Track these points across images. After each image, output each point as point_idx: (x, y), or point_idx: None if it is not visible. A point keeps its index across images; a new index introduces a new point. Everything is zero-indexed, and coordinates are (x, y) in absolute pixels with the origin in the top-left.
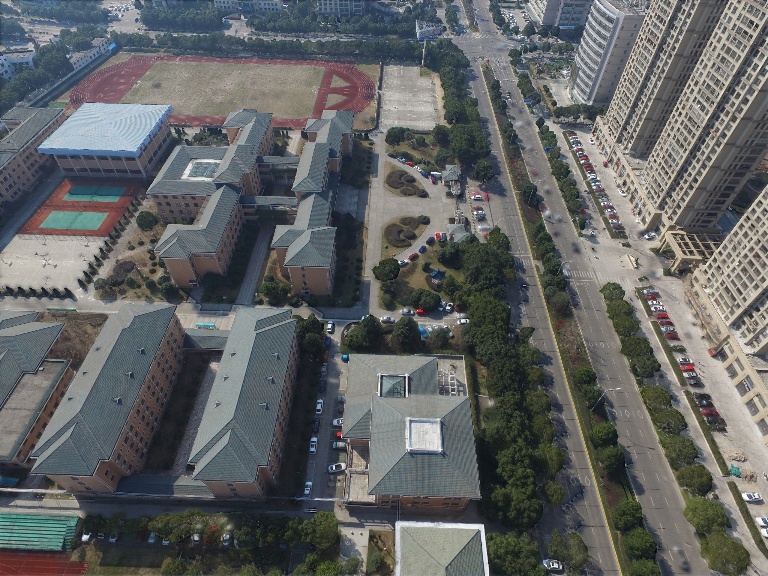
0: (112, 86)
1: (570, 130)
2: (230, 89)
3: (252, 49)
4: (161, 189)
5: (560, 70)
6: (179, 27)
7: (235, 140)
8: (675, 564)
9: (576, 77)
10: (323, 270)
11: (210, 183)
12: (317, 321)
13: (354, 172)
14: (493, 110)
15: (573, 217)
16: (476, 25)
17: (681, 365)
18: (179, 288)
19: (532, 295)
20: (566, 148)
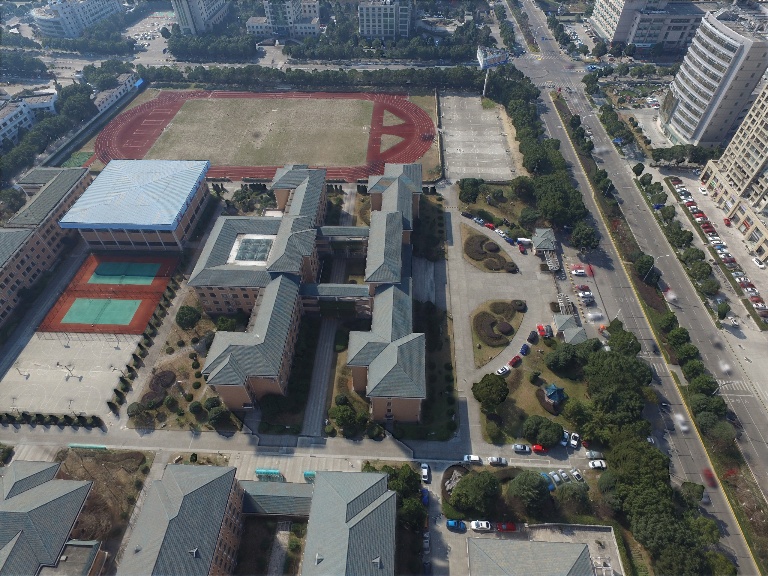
0: (140, 131)
1: (673, 176)
2: (271, 131)
3: (291, 81)
4: (205, 280)
5: (643, 97)
6: (210, 57)
7: (287, 207)
8: None
9: (673, 110)
10: (415, 399)
11: (263, 271)
12: (414, 476)
13: (425, 238)
14: (575, 151)
15: (704, 299)
16: (535, 44)
17: None
18: (230, 411)
19: (677, 419)
20: (673, 200)
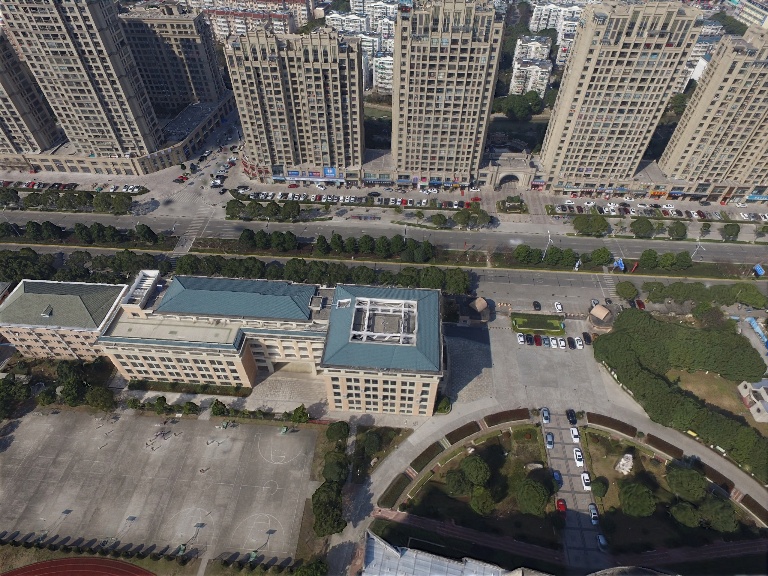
0: None
1: None
2: None
3: None
4: None
5: None
6: None
7: None
8: (122, 227)
9: None
10: None
11: None
12: None
13: None
14: None
15: None
16: None
17: (28, 187)
18: None
19: None
20: None
